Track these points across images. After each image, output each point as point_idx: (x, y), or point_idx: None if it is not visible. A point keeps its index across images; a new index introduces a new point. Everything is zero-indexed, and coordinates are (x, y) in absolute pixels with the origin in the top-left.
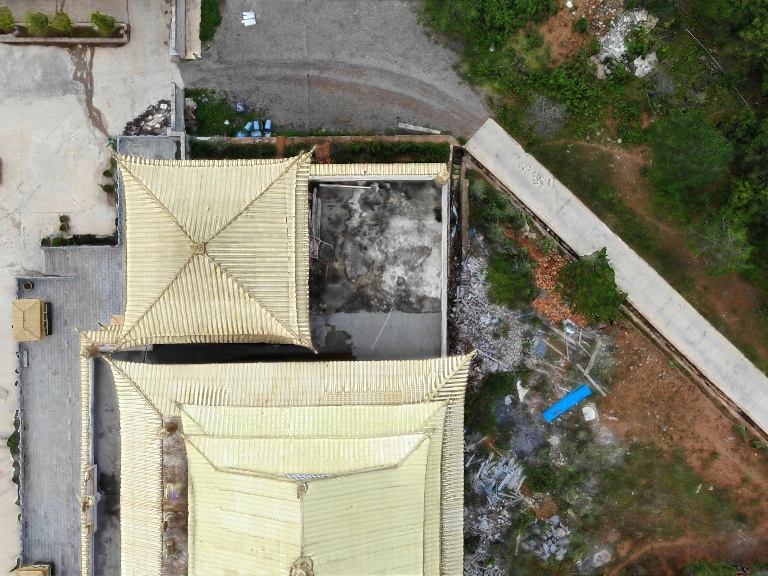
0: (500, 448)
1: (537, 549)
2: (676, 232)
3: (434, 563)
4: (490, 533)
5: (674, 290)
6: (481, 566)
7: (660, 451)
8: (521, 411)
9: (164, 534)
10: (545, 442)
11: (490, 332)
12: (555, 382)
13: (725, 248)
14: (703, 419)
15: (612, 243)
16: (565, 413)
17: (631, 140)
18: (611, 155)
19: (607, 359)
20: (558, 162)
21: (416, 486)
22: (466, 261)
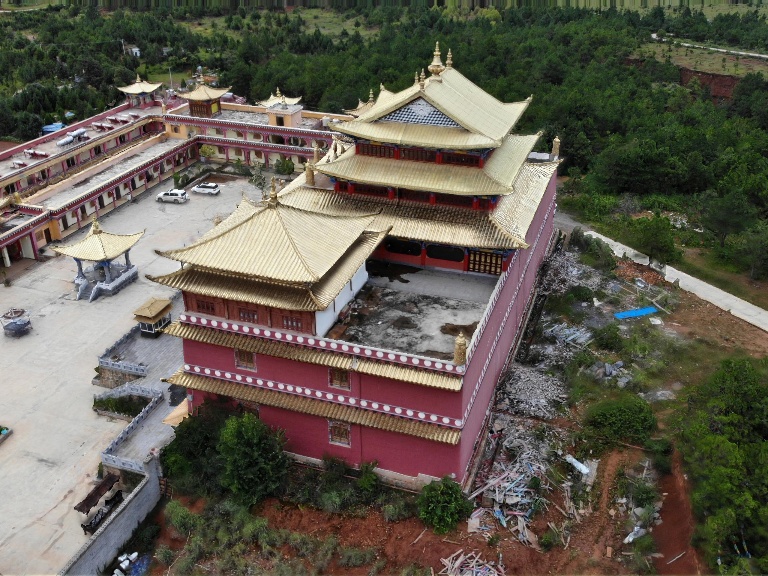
0: (573, 322)
1: (598, 369)
2: (729, 275)
3: (511, 174)
4: (554, 360)
5: (730, 294)
6: (541, 373)
7: (723, 346)
8: (595, 309)
9: None
10: (614, 325)
11: (575, 277)
12: (626, 303)
13: (756, 230)
14: (763, 339)
15: (678, 273)
16: (634, 318)
17: (692, 245)
18: (677, 248)
19: (672, 300)
20: (638, 245)
21: (512, 115)
22: (563, 252)
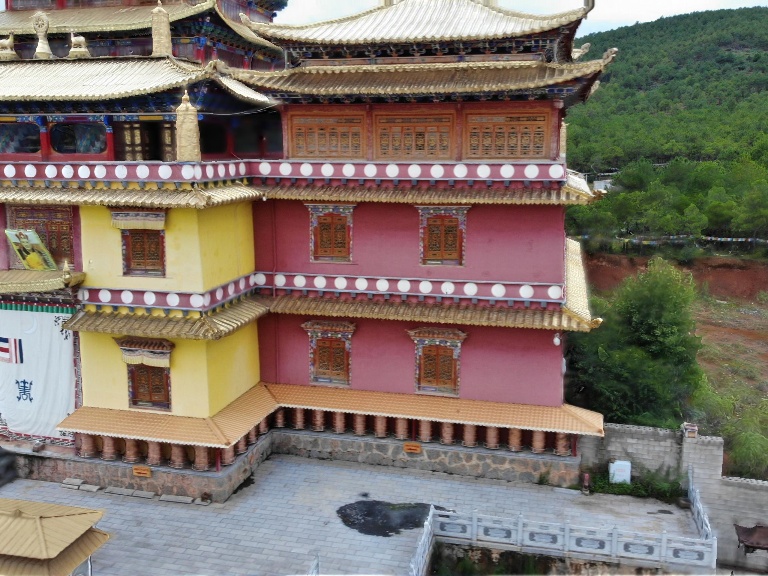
0: None
1: None
2: None
3: None
4: None
5: None
6: None
7: None
8: None
9: (55, 58)
10: None
11: None
12: None
13: None
14: None
15: None
16: None
17: None
18: None
19: None
20: None
21: None
22: None
